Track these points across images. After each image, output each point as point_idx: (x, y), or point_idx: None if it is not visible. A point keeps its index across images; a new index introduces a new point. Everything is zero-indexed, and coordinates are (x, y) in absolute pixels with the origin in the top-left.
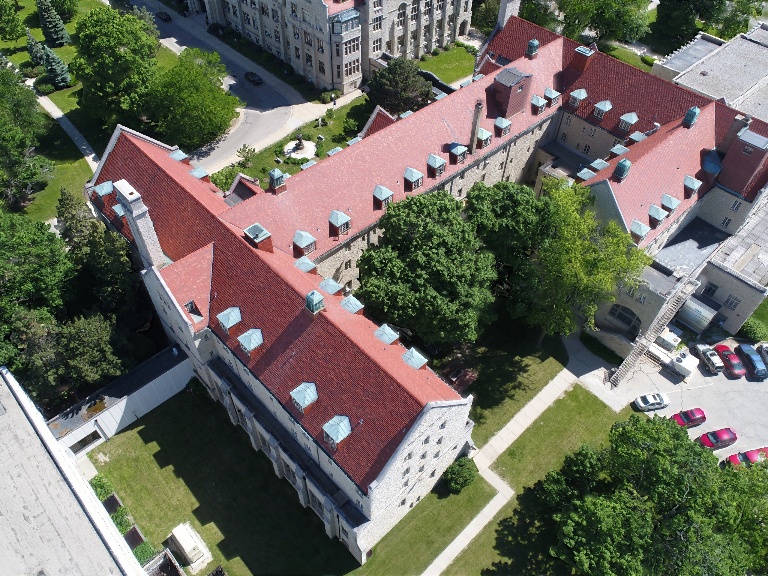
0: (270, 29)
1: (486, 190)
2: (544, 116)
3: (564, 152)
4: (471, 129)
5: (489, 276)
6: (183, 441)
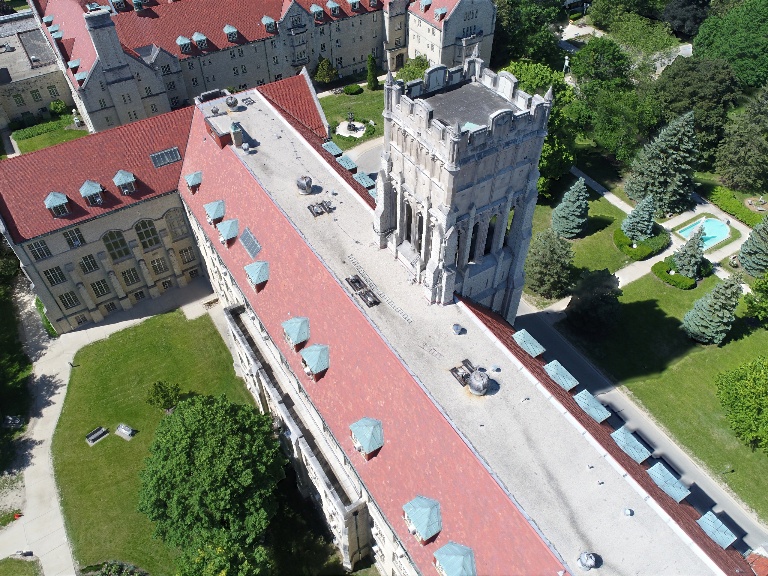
0: None
1: None
2: None
3: None
4: None
5: None
6: None
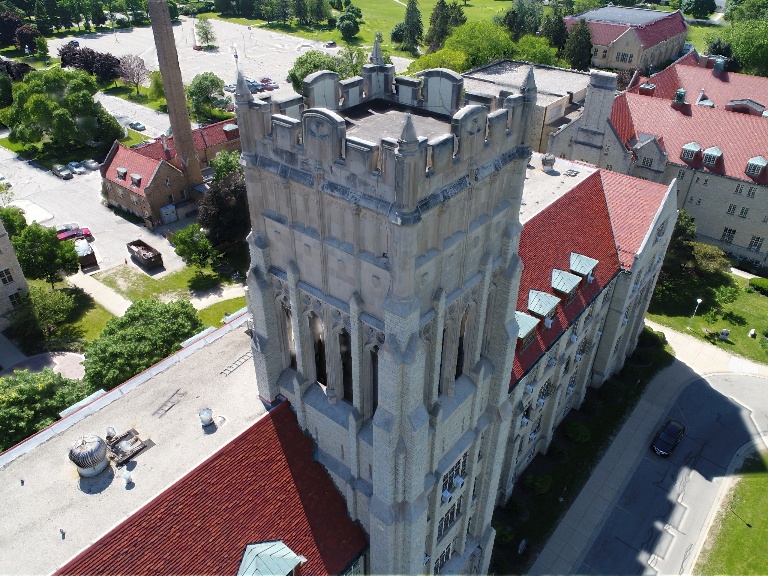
0: None
1: None
2: None
3: None
4: None
5: None
6: None
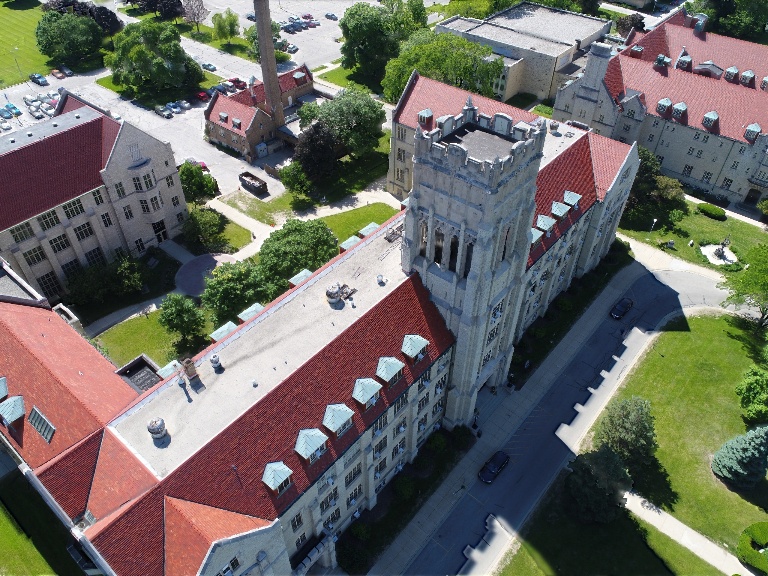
0: (554, 279)
1: None
2: None
3: None
4: None
5: None
6: None
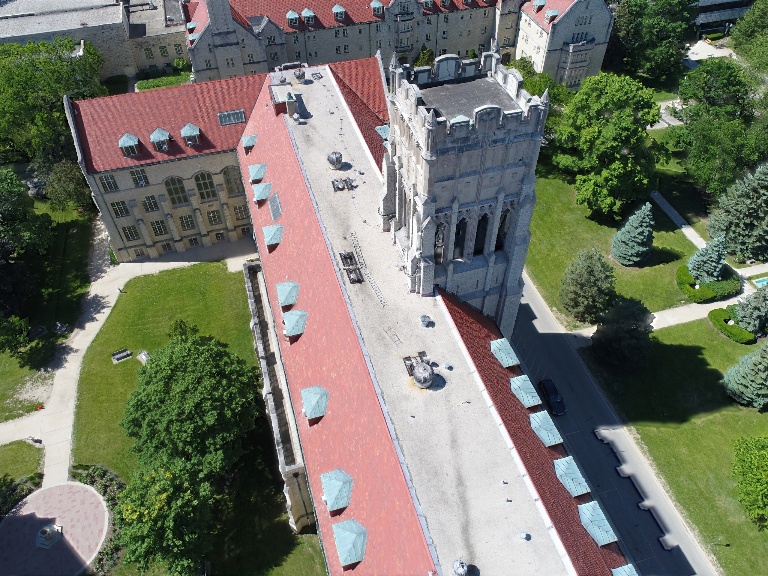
0: None
1: None
2: None
3: None
4: None
5: None
6: None
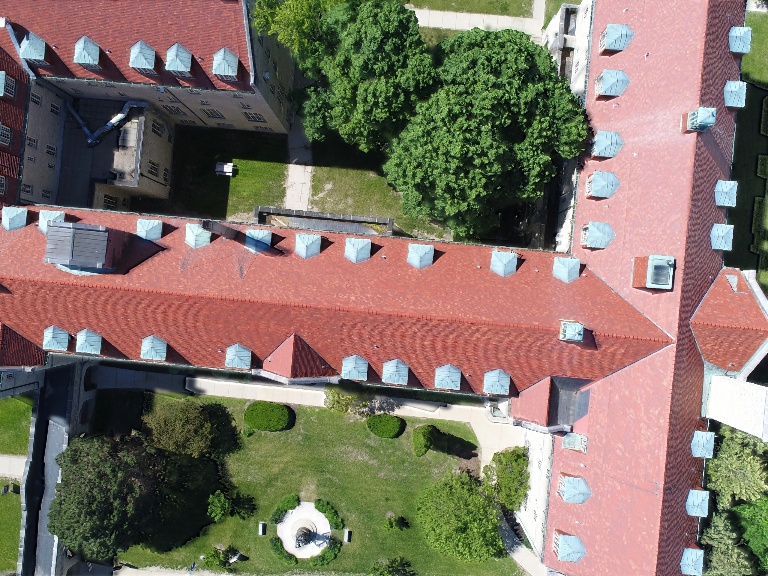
0: None
1: (376, 95)
2: (62, 210)
3: (70, 184)
4: (207, 251)
5: (473, 30)
6: (727, 263)
